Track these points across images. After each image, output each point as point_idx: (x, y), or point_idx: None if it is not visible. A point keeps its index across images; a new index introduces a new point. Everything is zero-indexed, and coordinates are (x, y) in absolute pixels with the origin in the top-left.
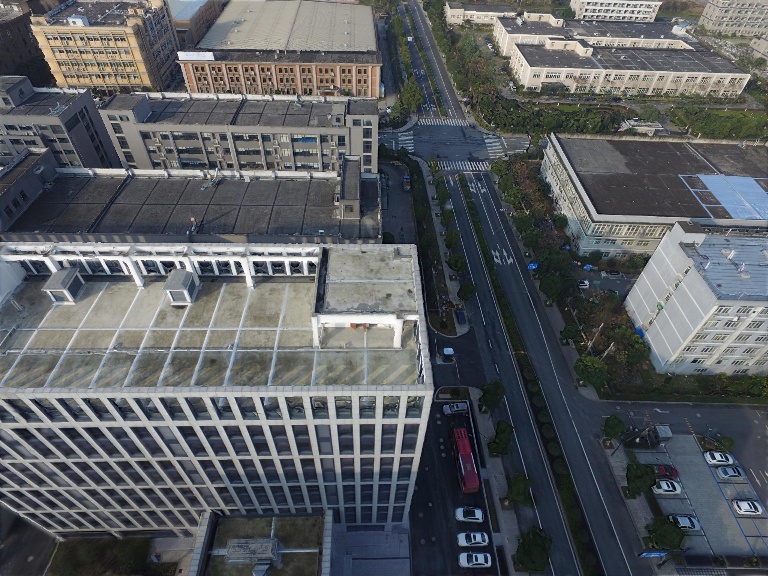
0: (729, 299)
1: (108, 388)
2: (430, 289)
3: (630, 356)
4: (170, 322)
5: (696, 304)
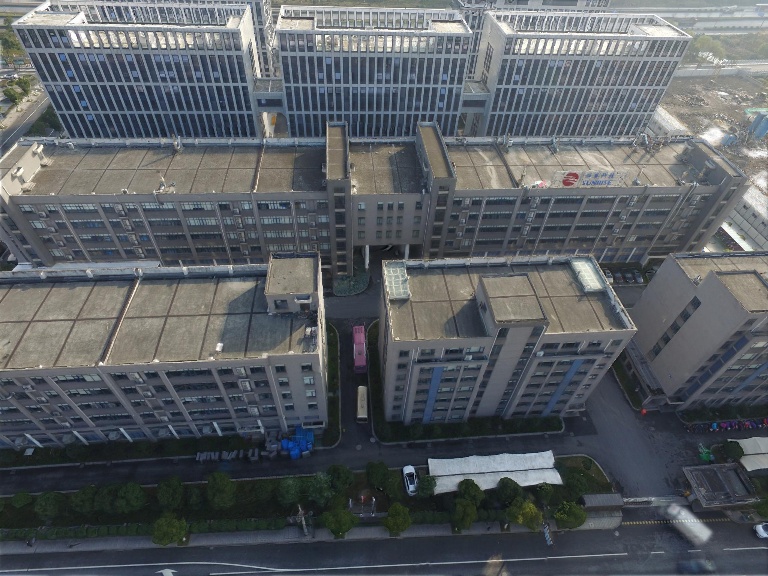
0: None
1: (161, 3)
2: (1, 243)
3: None
4: None
5: None
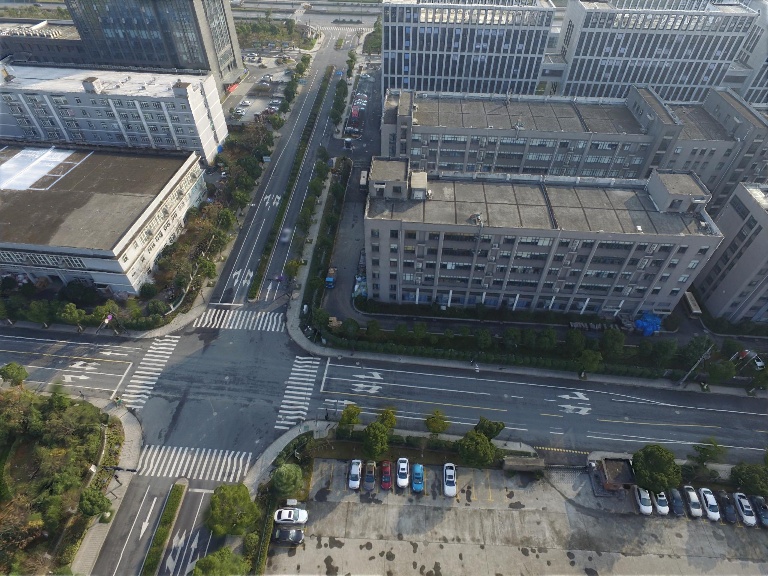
0: (206, 74)
1: None
2: None
3: (240, 139)
4: None
5: (213, 91)
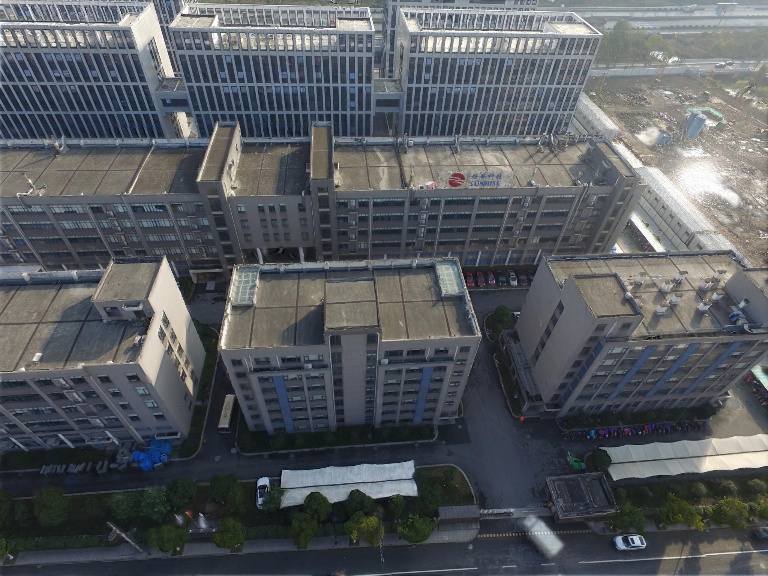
0: None
1: (60, 1)
2: None
3: None
4: (50, 37)
5: None
